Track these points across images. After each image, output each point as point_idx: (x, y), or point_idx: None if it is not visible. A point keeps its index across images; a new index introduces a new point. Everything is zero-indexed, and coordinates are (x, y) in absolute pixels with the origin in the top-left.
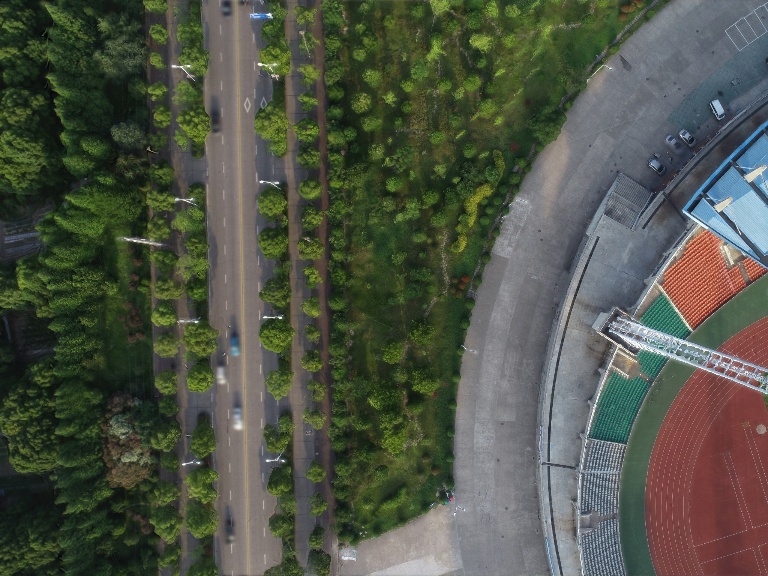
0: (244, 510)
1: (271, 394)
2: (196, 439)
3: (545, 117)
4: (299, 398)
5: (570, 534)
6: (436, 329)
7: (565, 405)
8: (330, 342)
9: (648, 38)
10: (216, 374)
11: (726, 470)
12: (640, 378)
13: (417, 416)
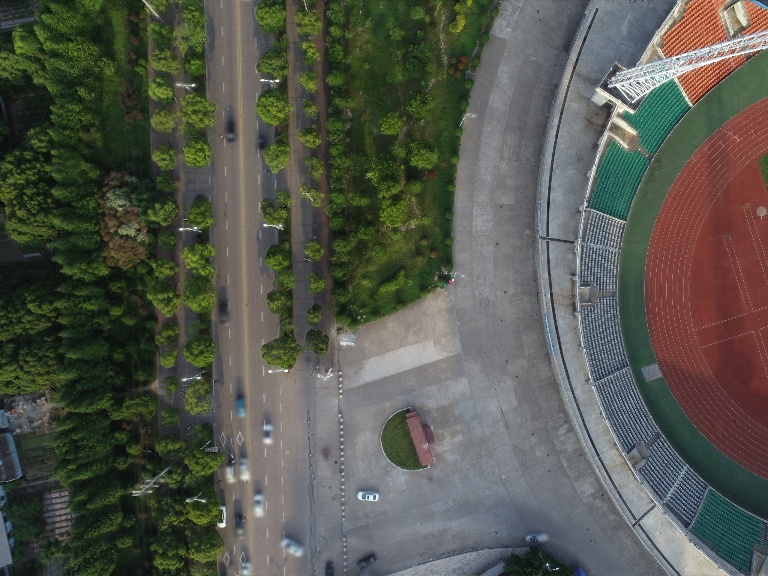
0: (242, 294)
1: (269, 177)
2: (193, 208)
3: None
4: (297, 181)
5: (569, 309)
6: (434, 102)
7: (564, 179)
8: (328, 118)
9: None
10: (213, 157)
11: (726, 252)
12: (639, 153)
13: (415, 198)
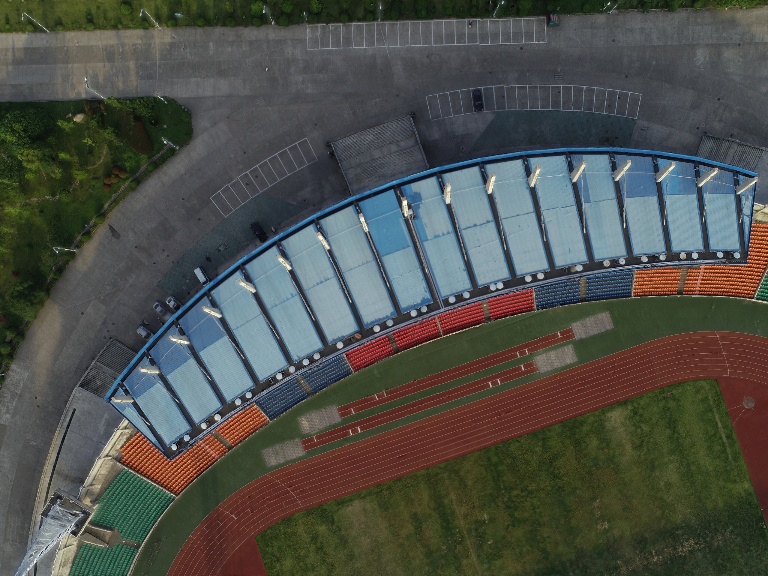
0: None
1: None
2: None
3: (18, 293)
4: None
5: None
6: None
7: (48, 574)
8: None
9: (135, 207)
10: None
11: None
12: (123, 545)
13: None
